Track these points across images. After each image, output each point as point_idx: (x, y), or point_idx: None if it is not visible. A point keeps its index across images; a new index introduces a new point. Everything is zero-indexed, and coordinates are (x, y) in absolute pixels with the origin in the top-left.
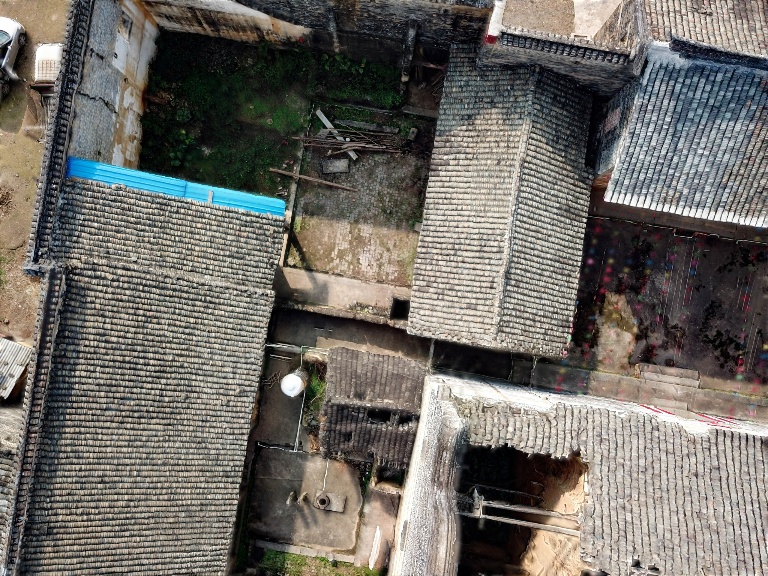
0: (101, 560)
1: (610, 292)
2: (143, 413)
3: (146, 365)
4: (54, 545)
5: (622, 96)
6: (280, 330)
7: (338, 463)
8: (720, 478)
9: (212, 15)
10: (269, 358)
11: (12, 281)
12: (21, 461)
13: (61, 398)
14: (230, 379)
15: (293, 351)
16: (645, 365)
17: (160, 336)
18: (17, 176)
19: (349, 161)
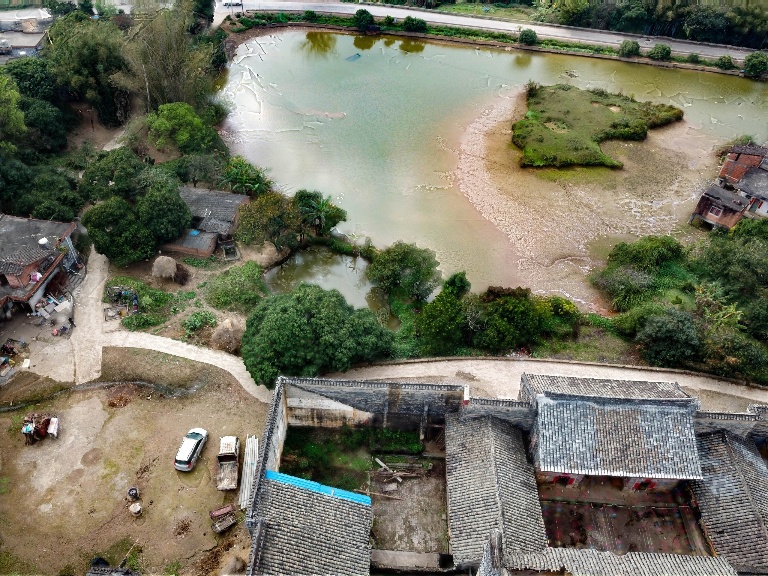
0: None
1: (568, 545)
2: None
3: None
4: None
5: (534, 427)
6: None
7: None
8: (640, 572)
9: (322, 412)
10: None
11: None
12: None
13: None
14: None
15: None
16: None
17: (311, 569)
18: (195, 512)
19: (397, 484)
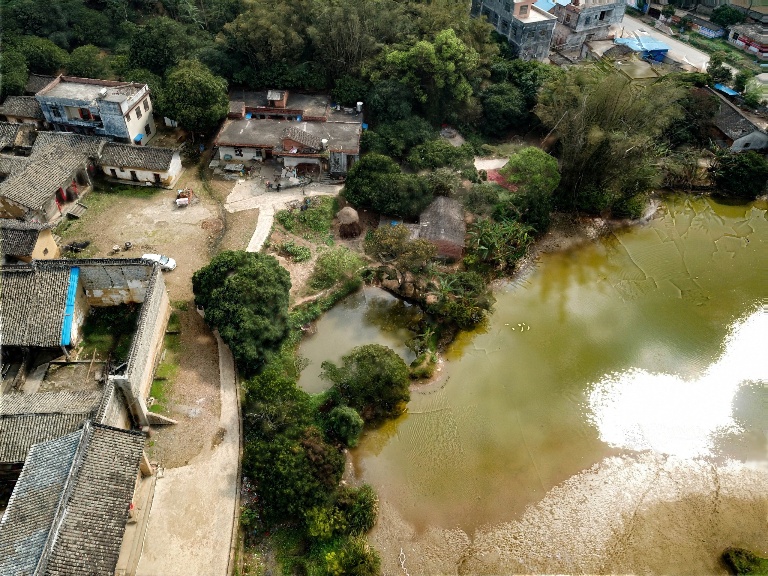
0: None
1: None
2: None
3: None
4: None
5: None
6: (16, 365)
7: None
8: None
9: None
10: (3, 363)
11: None
12: None
13: None
14: None
15: (4, 371)
16: None
17: (7, 305)
18: None
19: None
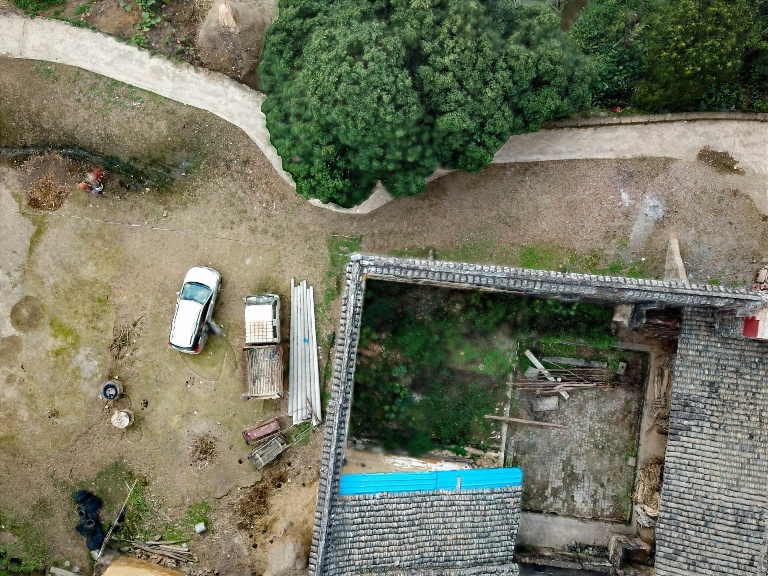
0: None
1: None
2: None
3: None
4: None
5: None
6: None
7: None
8: None
9: None
10: None
11: (219, 530)
12: None
13: None
14: None
15: None
16: None
17: None
18: (219, 424)
19: (559, 398)
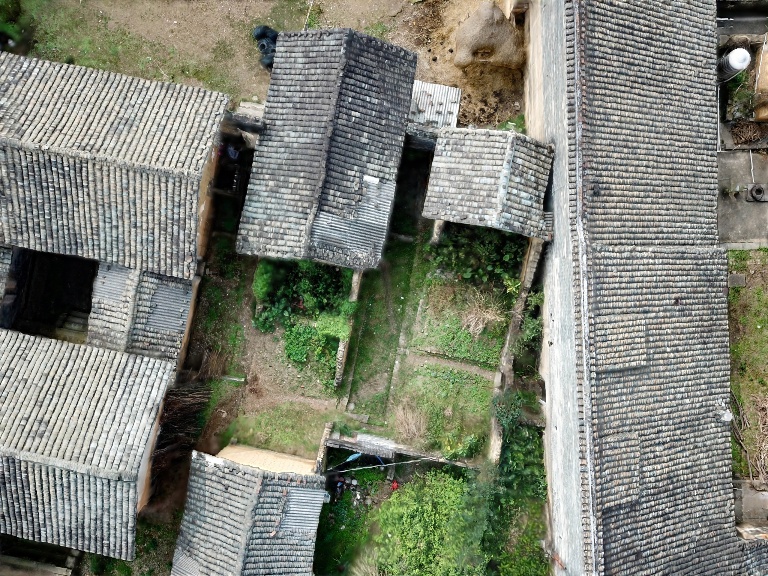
0: (636, 225)
1: None
2: (644, 79)
3: (639, 31)
4: (604, 207)
5: None
6: None
7: (761, 156)
8: None
9: None
10: None
11: None
12: (581, 112)
13: (589, 58)
14: (696, 50)
15: None
16: None
17: (644, 3)
18: None
19: None
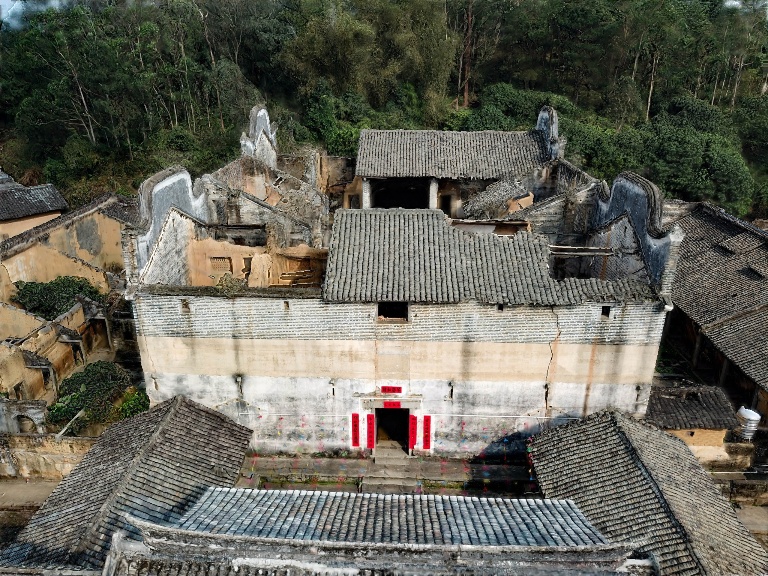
0: None
1: None
2: None
3: None
4: None
5: None
6: None
7: None
8: (457, 277)
9: None
10: None
11: None
12: None
13: None
14: None
15: (762, 468)
16: (416, 493)
17: None
18: None
19: None
